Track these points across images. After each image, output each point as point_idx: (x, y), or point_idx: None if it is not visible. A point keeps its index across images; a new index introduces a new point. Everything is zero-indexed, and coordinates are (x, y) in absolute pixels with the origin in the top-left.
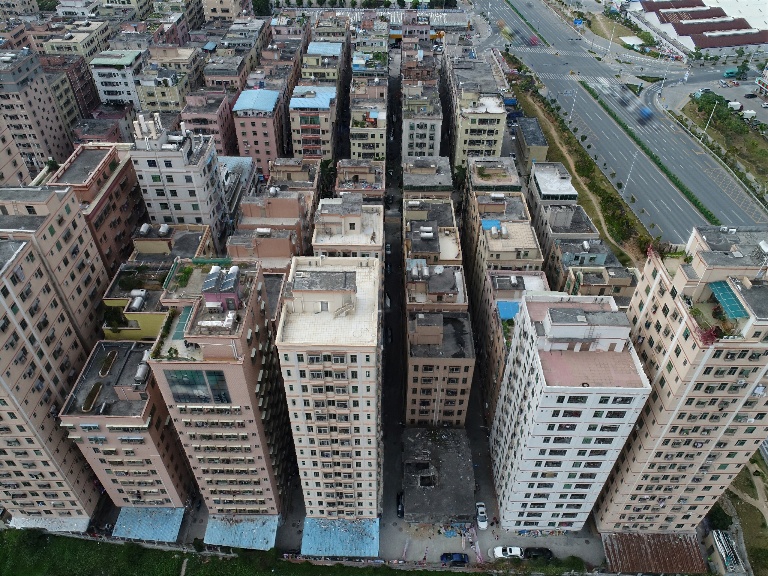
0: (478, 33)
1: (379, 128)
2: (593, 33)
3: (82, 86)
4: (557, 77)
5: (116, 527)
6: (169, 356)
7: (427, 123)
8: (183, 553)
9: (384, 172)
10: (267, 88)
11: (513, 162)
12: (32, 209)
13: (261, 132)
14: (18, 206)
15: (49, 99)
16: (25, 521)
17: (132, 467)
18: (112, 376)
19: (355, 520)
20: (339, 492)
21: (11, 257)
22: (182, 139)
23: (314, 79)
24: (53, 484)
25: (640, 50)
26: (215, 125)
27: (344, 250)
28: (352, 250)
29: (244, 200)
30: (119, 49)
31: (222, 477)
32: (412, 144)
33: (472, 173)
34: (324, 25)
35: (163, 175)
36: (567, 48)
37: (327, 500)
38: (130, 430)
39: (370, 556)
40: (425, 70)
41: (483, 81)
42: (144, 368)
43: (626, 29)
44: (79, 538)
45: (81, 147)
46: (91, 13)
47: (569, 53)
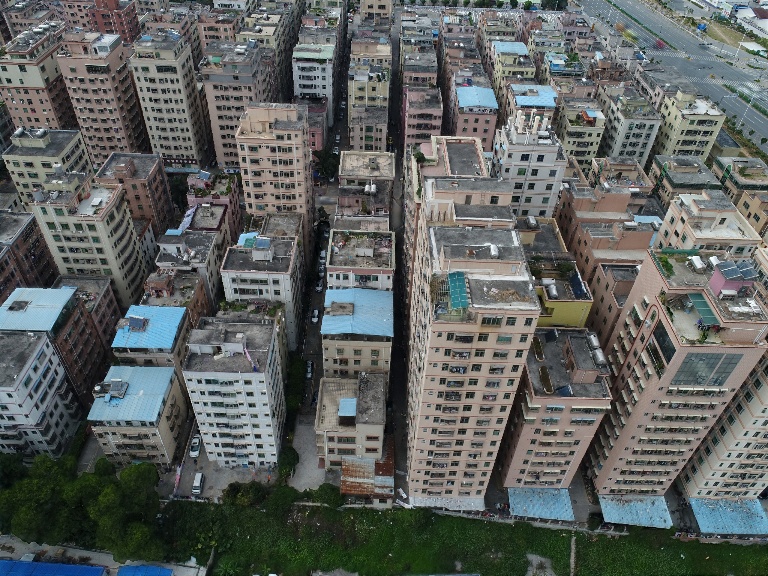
0: (602, 35)
1: (598, 127)
2: (711, 38)
3: (274, 79)
4: (699, 80)
5: (512, 506)
6: (702, 340)
7: (646, 123)
8: (571, 532)
9: (642, 170)
10: (474, 85)
11: (763, 163)
12: (496, 199)
13: (482, 128)
14: (486, 196)
15: (263, 91)
16: (423, 500)
17: (556, 448)
18: (548, 360)
19: (737, 500)
20: (743, 473)
21: (514, 244)
22: (548, 134)
23: (521, 78)
24: (481, 464)
25: (767, 56)
26: (438, 121)
27: (723, 244)
28: (730, 244)
29: (575, 194)
30: (307, 43)
31: (645, 458)
32: (626, 143)
33: (733, 172)
34: (493, 24)
35: (530, 169)
36: (694, 52)
37: (728, 481)
38: (591, 411)
39: (767, 534)
40: (618, 71)
41: (681, 83)
42: (602, 353)
43: (742, 35)
44: (465, 517)
45: (445, 140)
46: (246, 6)
47: (698, 57)
